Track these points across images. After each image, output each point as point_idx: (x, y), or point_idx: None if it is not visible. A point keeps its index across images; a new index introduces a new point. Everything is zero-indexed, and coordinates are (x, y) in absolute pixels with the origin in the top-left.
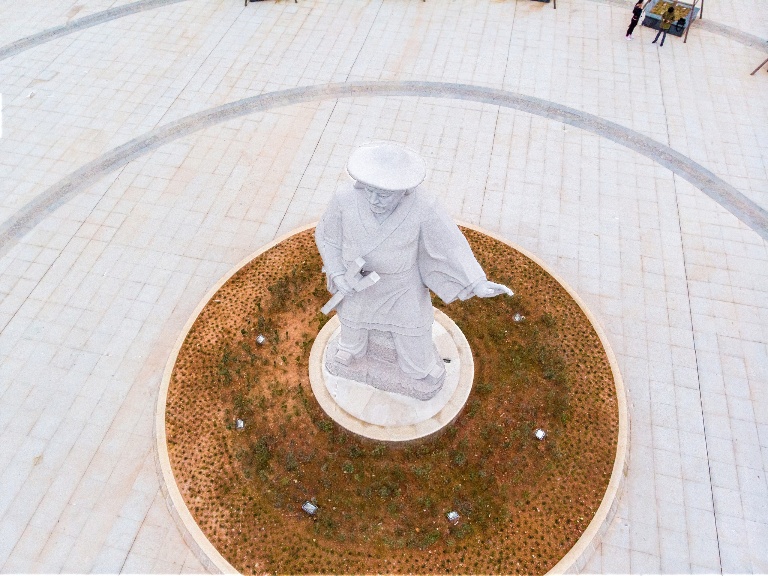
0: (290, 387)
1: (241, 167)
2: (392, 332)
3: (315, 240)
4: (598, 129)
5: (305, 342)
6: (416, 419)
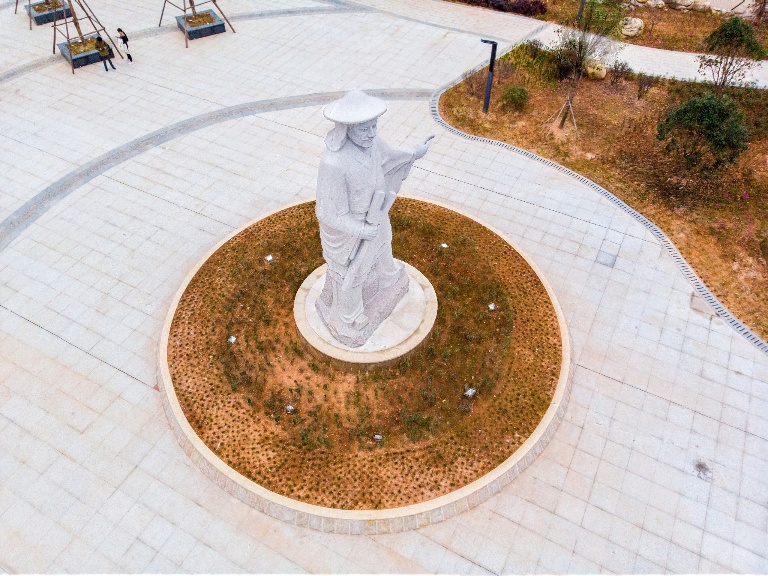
0: (354, 391)
1: (6, 406)
2: (376, 260)
3: (331, 225)
4: (180, 132)
5: (312, 369)
6: (422, 300)
